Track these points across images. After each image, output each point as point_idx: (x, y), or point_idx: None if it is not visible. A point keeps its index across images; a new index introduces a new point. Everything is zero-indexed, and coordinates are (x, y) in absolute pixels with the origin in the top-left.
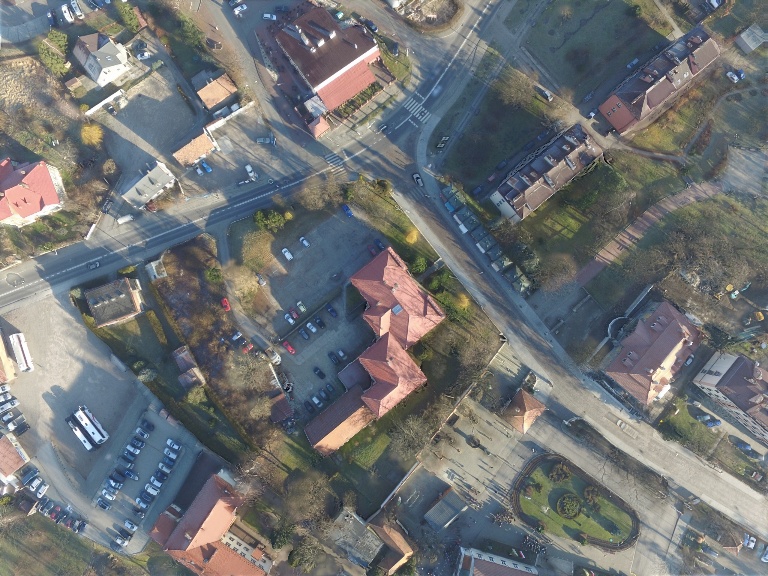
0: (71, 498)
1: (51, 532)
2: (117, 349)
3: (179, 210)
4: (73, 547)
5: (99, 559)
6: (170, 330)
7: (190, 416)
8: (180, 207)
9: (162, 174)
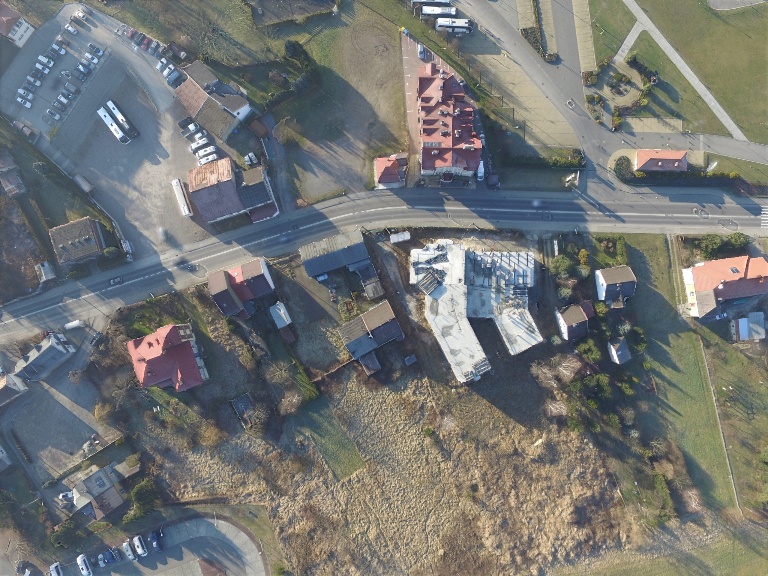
0: (134, 57)
1: (163, 27)
2: (79, 196)
3: (27, 332)
4: (141, 13)
5: (116, 1)
6: (34, 213)
7: (4, 128)
8: (25, 335)
9: (19, 366)
